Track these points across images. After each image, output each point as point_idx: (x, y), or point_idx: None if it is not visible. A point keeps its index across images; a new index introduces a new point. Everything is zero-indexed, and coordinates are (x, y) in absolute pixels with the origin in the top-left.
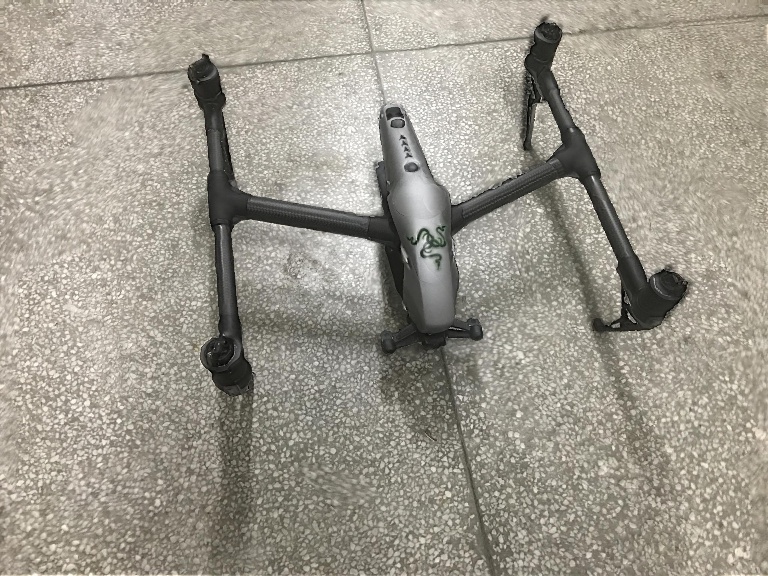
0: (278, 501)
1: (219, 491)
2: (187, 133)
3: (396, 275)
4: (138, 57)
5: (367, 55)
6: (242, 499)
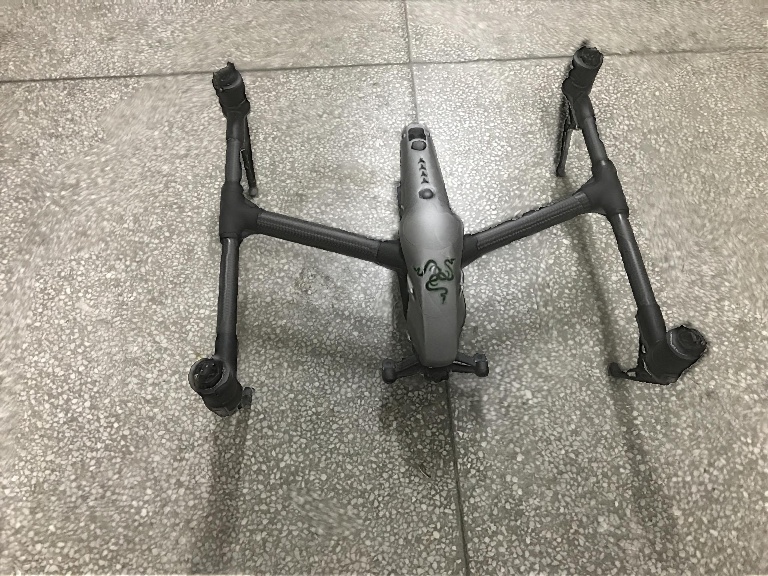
0: (263, 523)
1: (205, 507)
2: (215, 136)
3: (405, 301)
4: (176, 55)
5: (404, 66)
6: (227, 518)
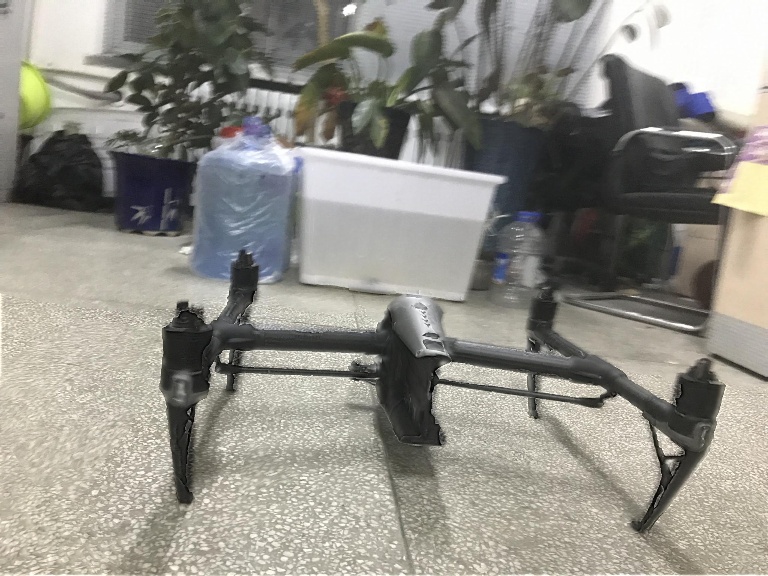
0: (492, 384)
1: None
2: None
3: None
4: None
5: None
6: None
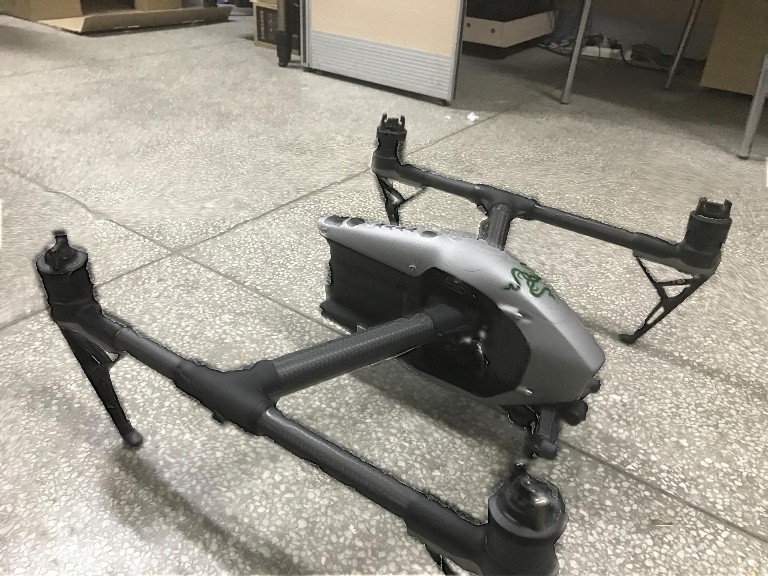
0: None
1: None
2: None
3: (464, 384)
4: None
5: (171, 257)
6: None
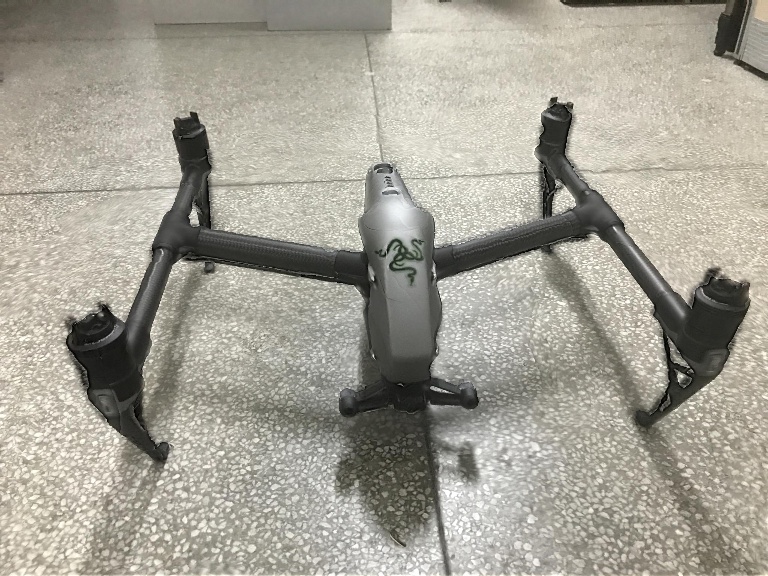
0: None
1: None
2: None
3: None
4: (151, 177)
5: None
6: None
